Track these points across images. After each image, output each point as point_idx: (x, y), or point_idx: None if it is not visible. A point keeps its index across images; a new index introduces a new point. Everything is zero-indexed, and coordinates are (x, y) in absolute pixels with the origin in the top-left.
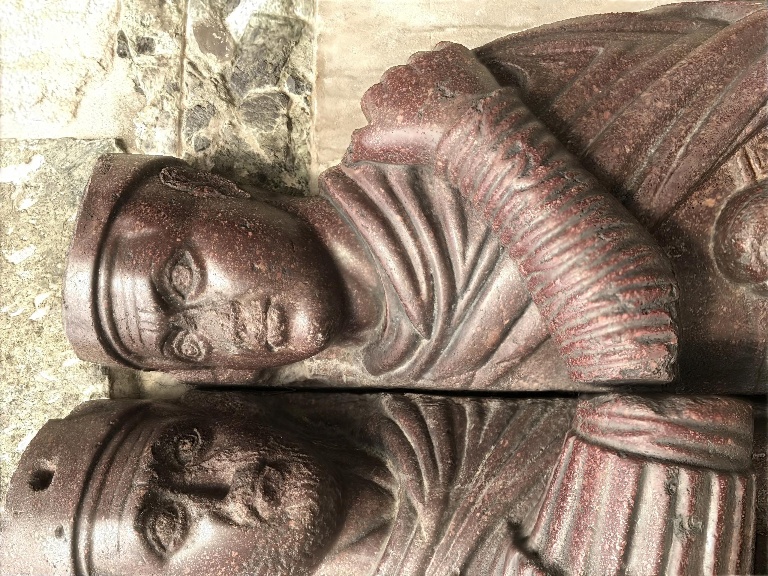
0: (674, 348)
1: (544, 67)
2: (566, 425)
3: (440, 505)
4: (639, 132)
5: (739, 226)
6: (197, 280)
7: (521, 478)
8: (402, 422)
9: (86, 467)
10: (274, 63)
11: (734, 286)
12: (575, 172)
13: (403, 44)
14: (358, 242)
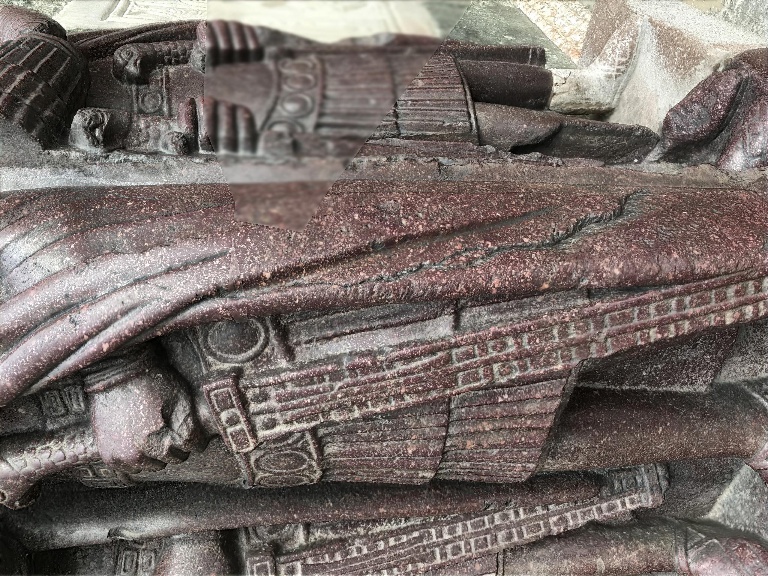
0: (46, 27)
1: None
2: None
3: None
4: (82, 33)
5: None
6: None
7: None
8: None
9: None
10: None
11: (121, 83)
12: None
13: None
14: None
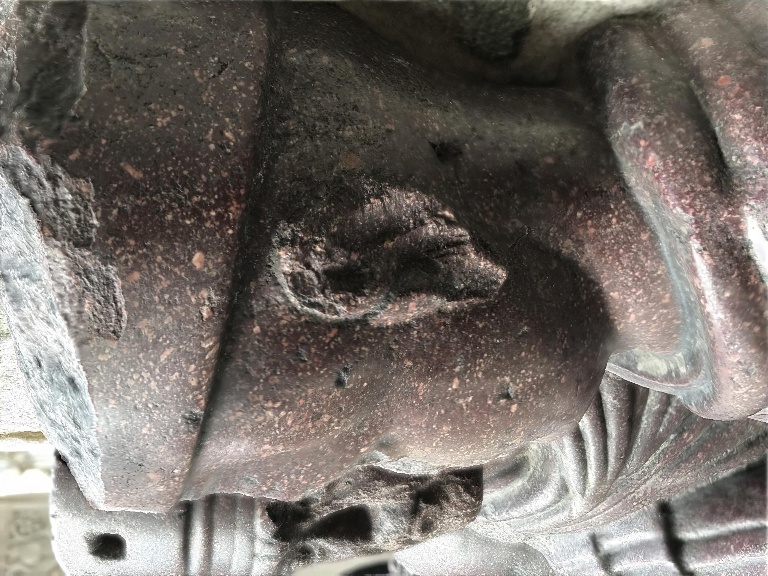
0: None
1: None
2: (764, 428)
3: None
4: None
5: None
6: None
7: (693, 479)
8: None
9: (179, 545)
10: None
11: None
12: None
13: None
14: (679, 331)
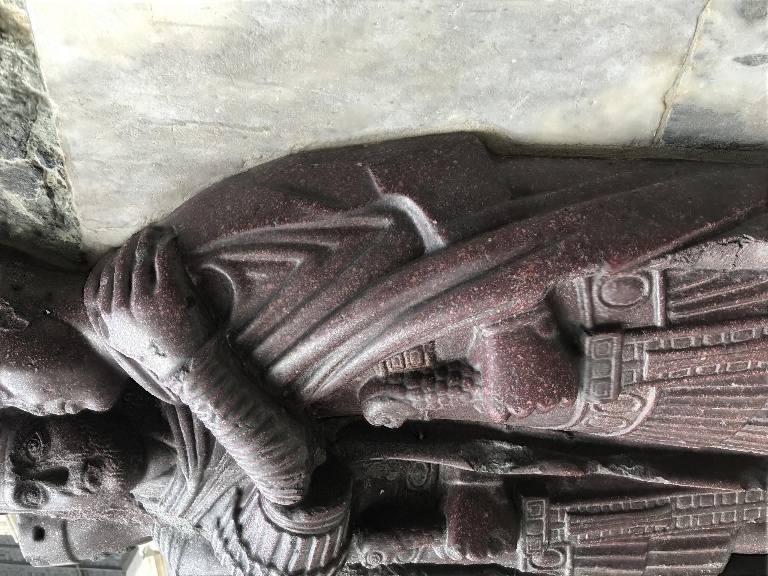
0: (299, 498)
1: (249, 279)
2: None
3: (197, 481)
4: (305, 363)
5: (365, 409)
6: (6, 396)
7: None
8: (178, 416)
9: None
10: (16, 137)
11: None
12: (246, 421)
13: (146, 134)
14: None
